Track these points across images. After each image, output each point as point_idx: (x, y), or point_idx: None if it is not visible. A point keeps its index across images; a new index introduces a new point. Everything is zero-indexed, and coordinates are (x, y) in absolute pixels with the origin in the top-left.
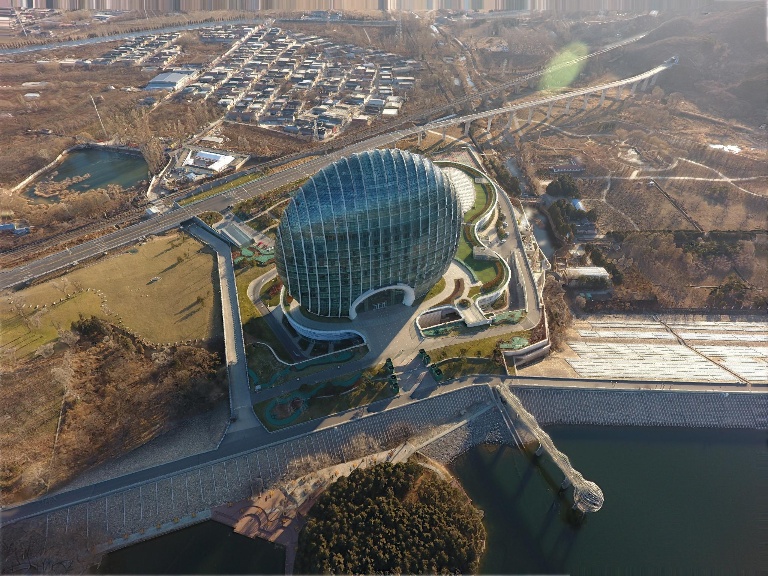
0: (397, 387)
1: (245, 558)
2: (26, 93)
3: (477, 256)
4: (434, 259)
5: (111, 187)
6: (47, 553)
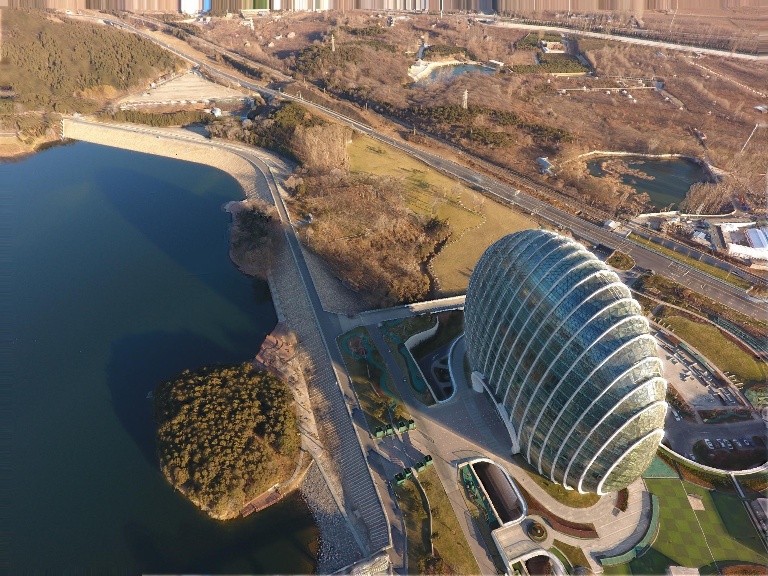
0: (377, 430)
1: (249, 345)
2: (760, 106)
3: (671, 572)
4: (546, 437)
5: (643, 195)
6: (258, 250)
